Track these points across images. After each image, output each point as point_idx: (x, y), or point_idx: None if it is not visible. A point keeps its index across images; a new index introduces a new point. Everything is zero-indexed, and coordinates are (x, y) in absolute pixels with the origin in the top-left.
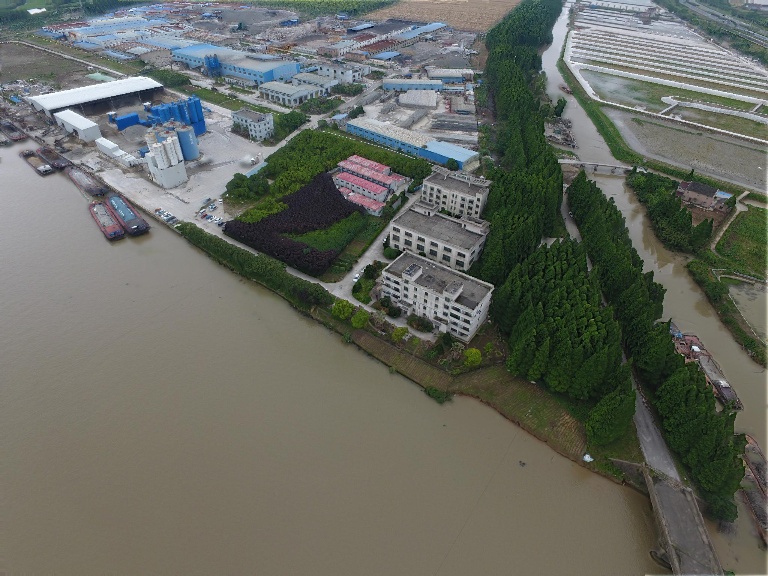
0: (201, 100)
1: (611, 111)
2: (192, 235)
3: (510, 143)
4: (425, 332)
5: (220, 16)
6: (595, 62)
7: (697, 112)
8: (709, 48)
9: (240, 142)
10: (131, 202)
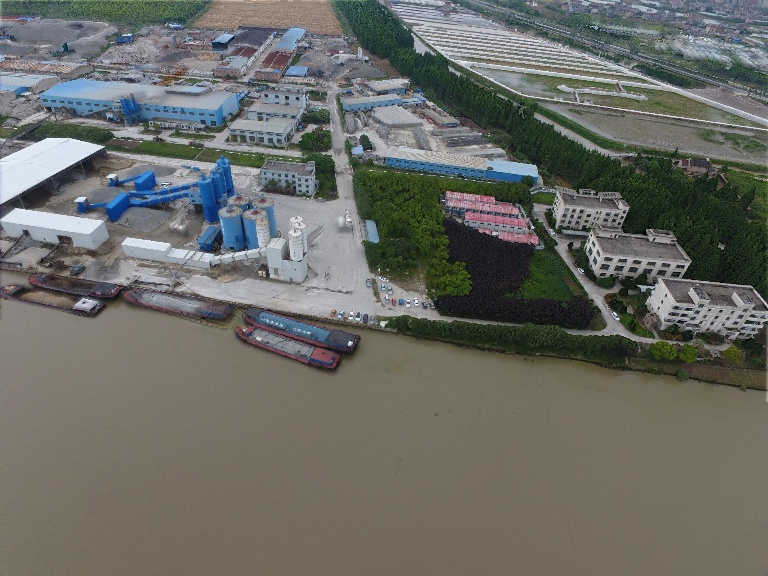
0: (161, 157)
1: (546, 105)
2: (424, 329)
3: (547, 150)
4: (721, 345)
5: (10, 34)
6: (471, 59)
7: (594, 97)
8: (523, 37)
9: (293, 202)
10: (280, 313)
